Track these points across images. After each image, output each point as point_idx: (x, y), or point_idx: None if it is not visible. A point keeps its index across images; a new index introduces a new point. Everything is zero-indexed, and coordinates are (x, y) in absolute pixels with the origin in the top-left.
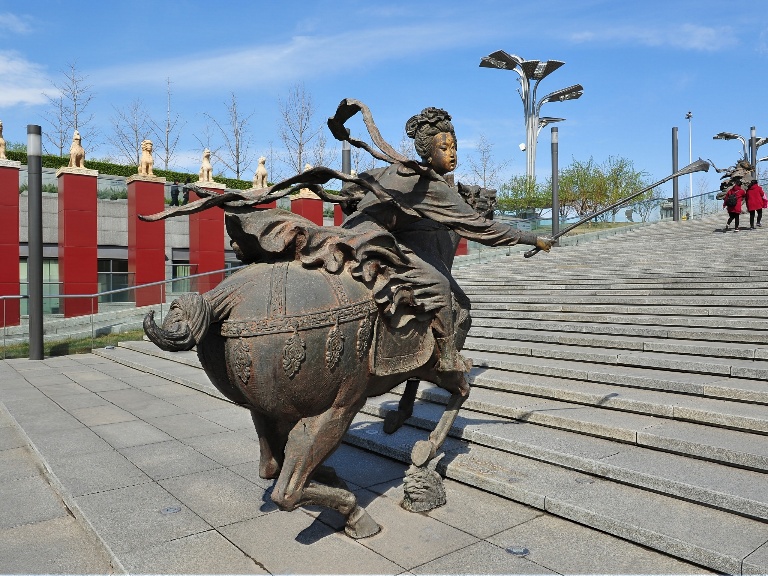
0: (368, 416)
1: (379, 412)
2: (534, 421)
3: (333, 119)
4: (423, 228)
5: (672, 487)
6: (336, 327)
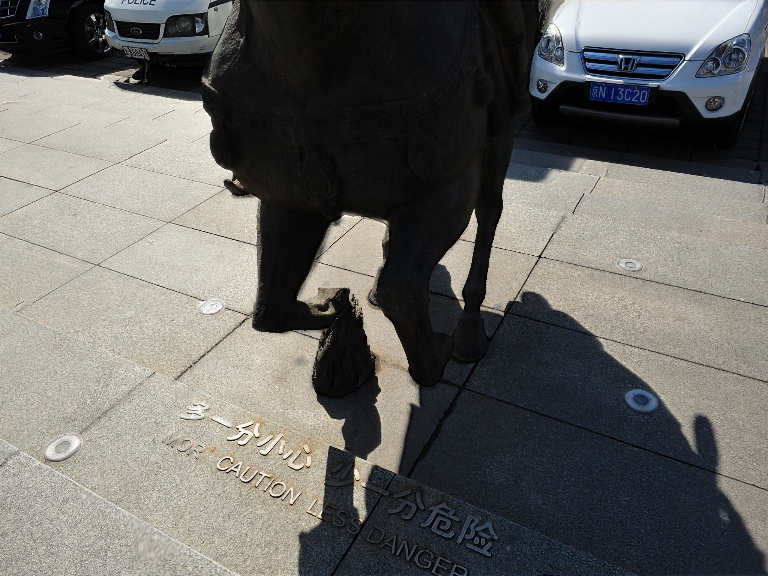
0: None
1: None
2: None
3: None
4: None
5: None
6: None
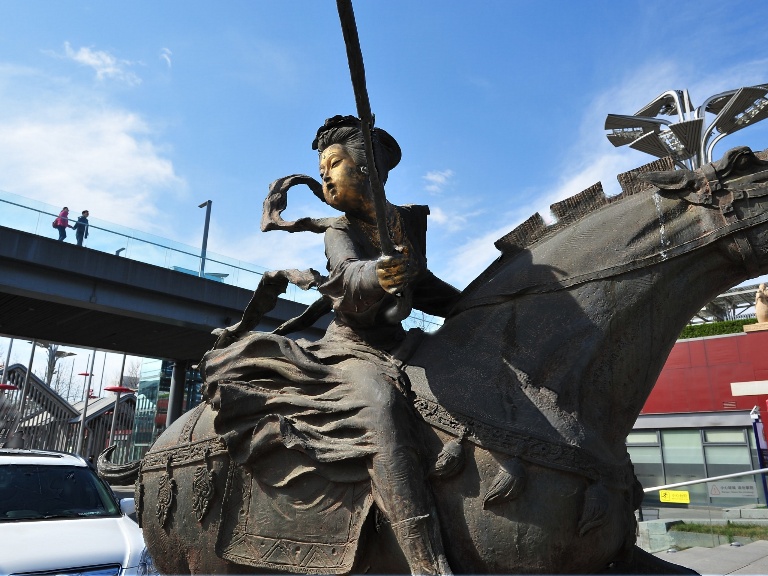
0: None
1: None
2: None
3: None
4: (477, 303)
5: None
6: (166, 472)
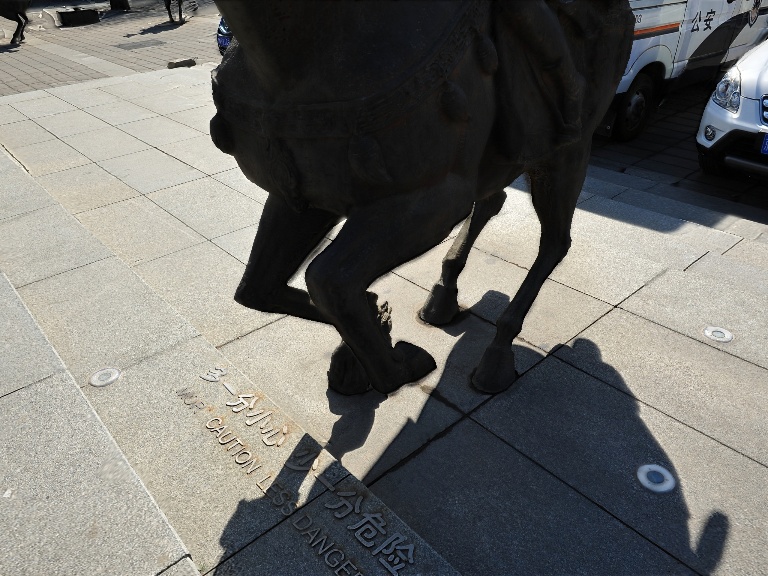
0: None
1: None
2: None
3: None
4: None
5: None
6: None
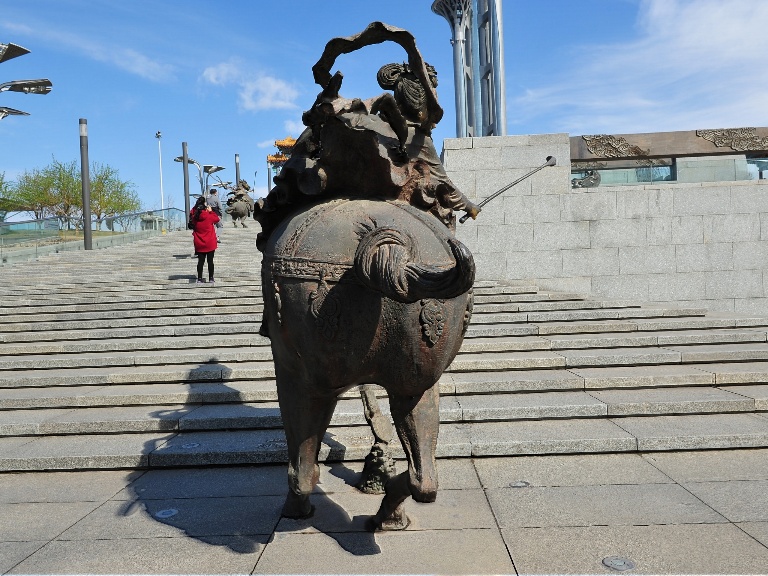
0: (140, 435)
1: (160, 426)
2: (350, 396)
3: (344, 41)
4: None
5: (531, 412)
6: None
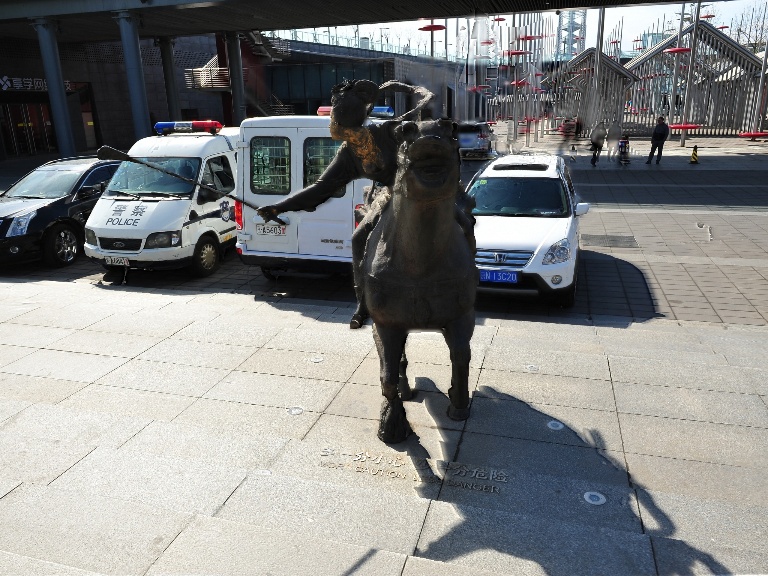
0: None
1: None
2: None
3: None
4: None
5: None
6: None
